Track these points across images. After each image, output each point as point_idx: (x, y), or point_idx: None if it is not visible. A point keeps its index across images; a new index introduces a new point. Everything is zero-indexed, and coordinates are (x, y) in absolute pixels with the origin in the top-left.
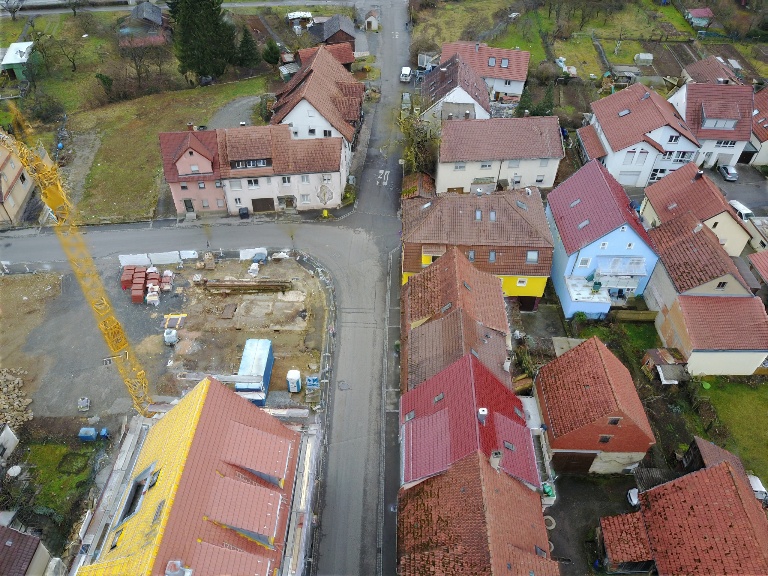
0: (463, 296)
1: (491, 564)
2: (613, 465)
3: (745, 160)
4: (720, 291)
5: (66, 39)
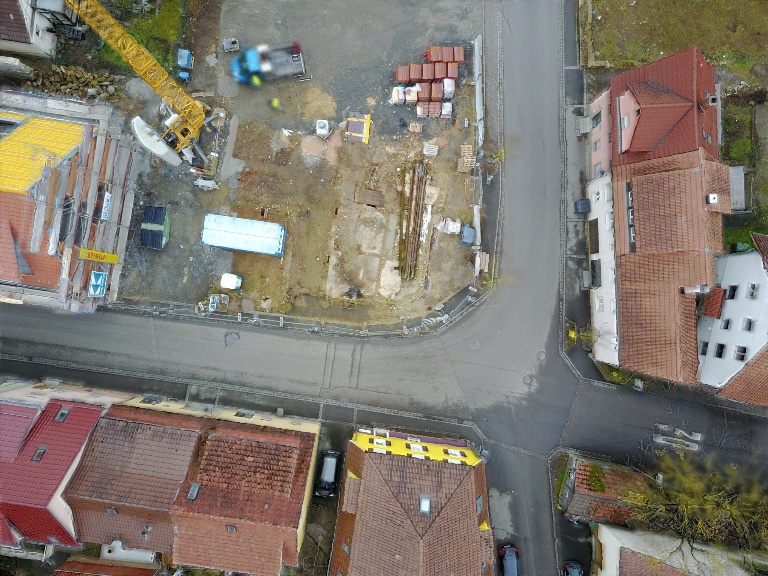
0: (201, 519)
1: None
2: None
3: None
4: None
5: None
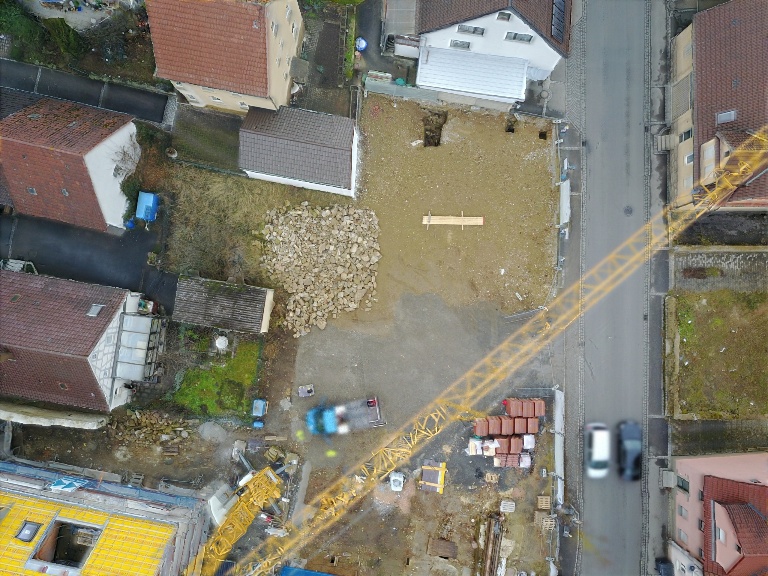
0: None
1: None
2: None
3: None
4: None
5: None
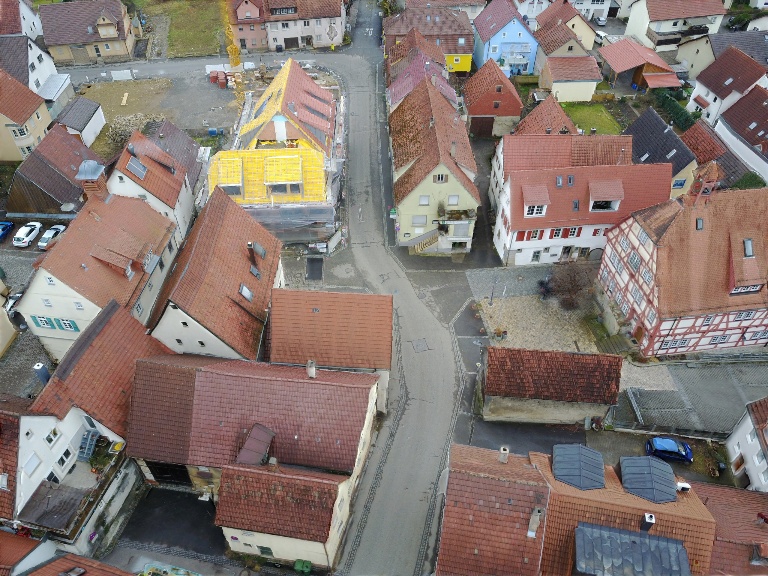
0: (419, 45)
1: (430, 100)
2: (504, 128)
3: (613, 15)
4: (570, 53)
5: None
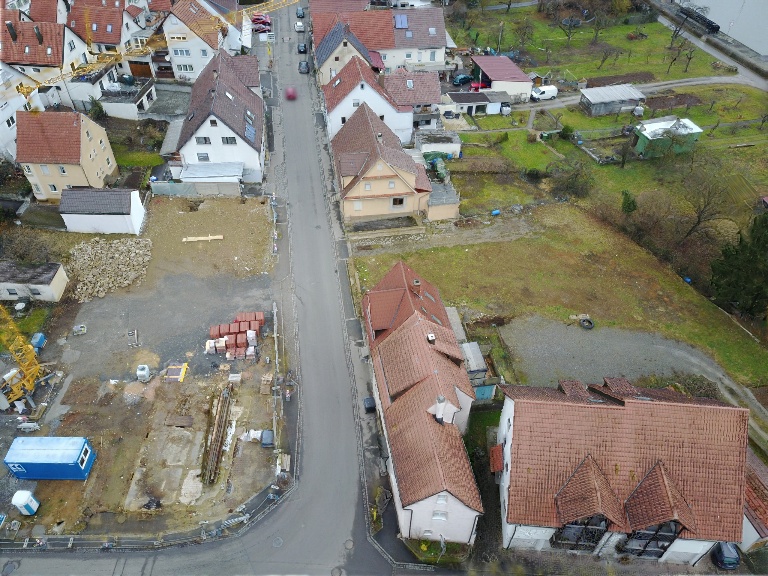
0: None
1: None
2: None
3: None
4: None
5: (764, 153)
